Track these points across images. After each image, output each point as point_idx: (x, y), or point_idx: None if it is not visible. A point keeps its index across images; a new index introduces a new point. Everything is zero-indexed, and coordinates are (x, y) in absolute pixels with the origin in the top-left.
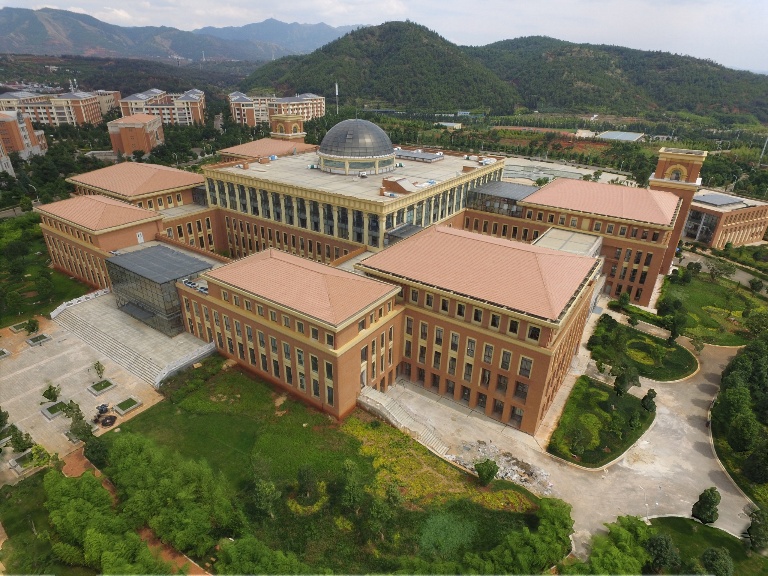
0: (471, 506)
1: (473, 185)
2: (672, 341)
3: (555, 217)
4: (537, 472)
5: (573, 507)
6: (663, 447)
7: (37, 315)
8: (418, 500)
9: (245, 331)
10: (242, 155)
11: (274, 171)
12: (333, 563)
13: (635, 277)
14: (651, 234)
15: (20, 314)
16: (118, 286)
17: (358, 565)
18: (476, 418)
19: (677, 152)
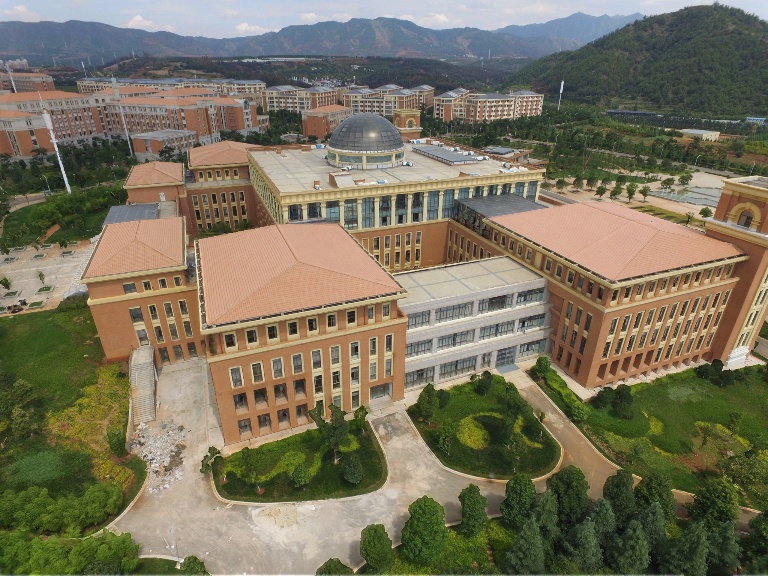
0: (82, 462)
1: (468, 194)
2: (506, 428)
3: (514, 244)
4: (175, 472)
5: (149, 512)
6: (320, 522)
7: None
8: (61, 438)
9: None
10: None
11: (293, 157)
12: None
13: (574, 342)
14: (596, 288)
15: (84, 236)
16: None
17: None
18: (211, 409)
19: None
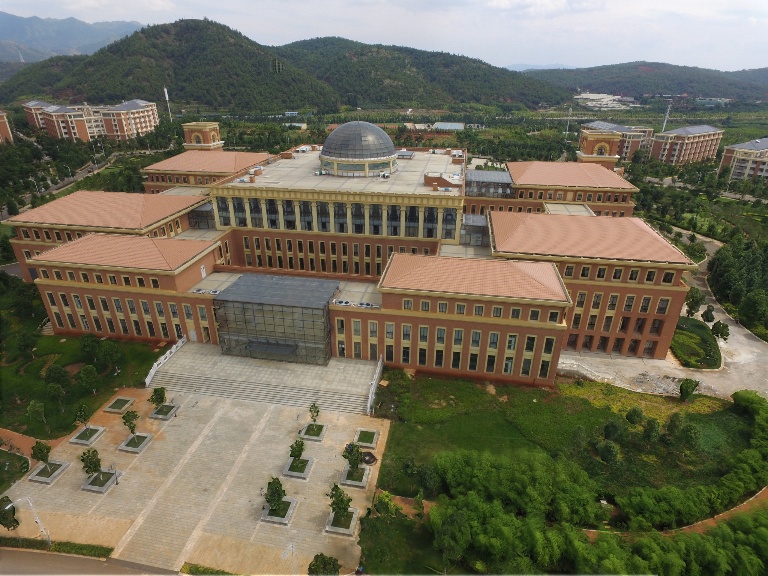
0: (697, 416)
1: None
2: None
3: (544, 194)
4: None
5: None
6: (733, 343)
7: (118, 388)
8: (667, 424)
9: (435, 334)
10: (181, 171)
11: (288, 181)
12: (679, 486)
13: None
14: (621, 197)
15: (95, 393)
16: (231, 327)
17: (693, 480)
18: (619, 359)
19: None
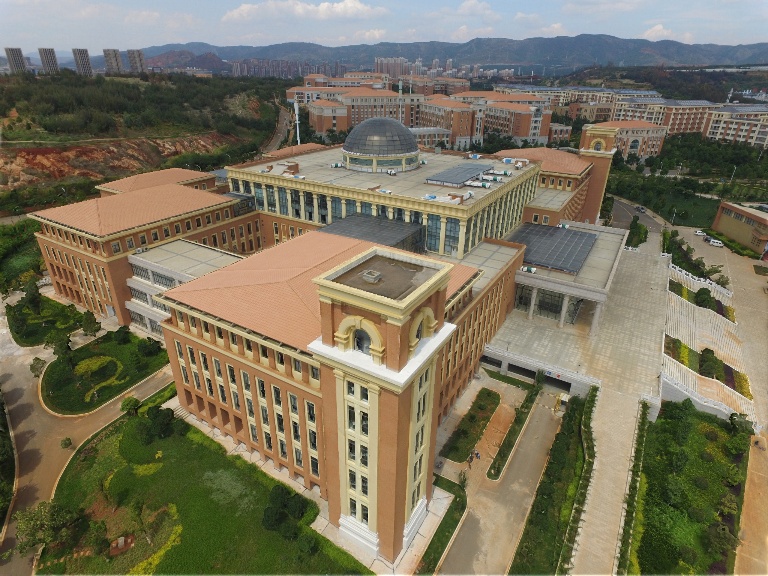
0: None
1: None
2: None
3: None
4: None
5: None
6: None
7: None
8: None
9: None
10: None
11: None
12: None
13: None
14: None
15: None
16: None
17: None
18: None
19: (412, 277)
